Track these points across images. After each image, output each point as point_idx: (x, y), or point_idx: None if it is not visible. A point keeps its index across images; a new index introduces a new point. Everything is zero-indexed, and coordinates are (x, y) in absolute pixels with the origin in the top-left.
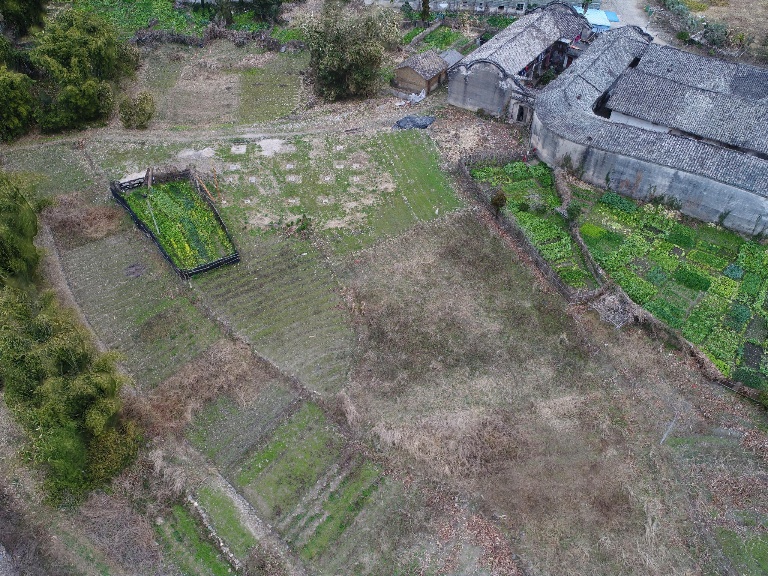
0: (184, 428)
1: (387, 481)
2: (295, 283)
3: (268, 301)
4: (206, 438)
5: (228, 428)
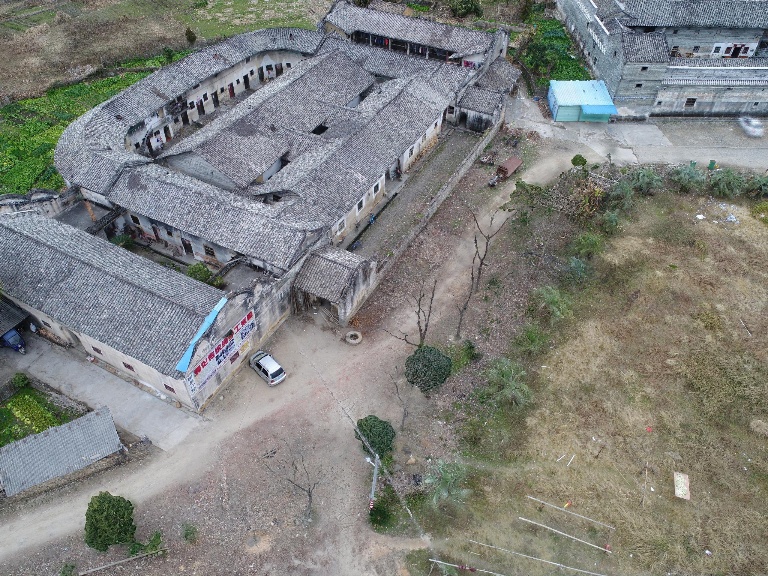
0: (77, 1)
1: None
2: (154, 8)
3: (143, 4)
4: (70, 5)
5: (73, 8)
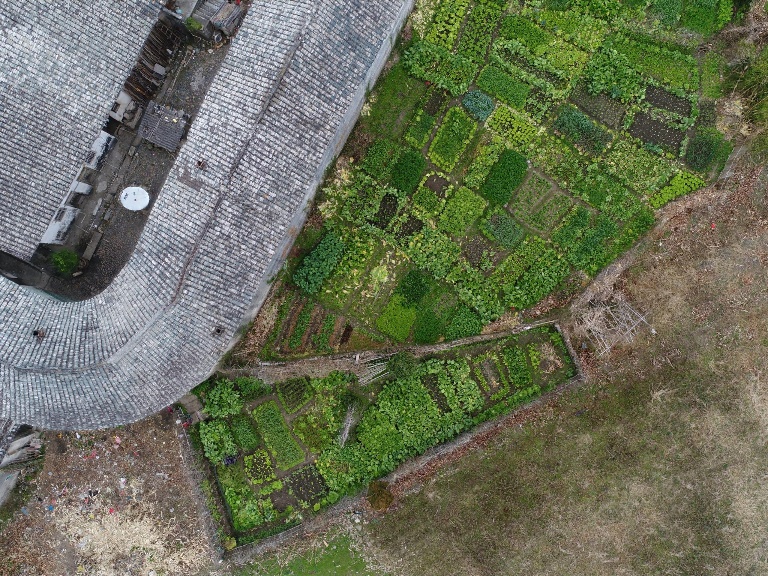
0: None
1: None
2: None
3: None
4: None
5: None
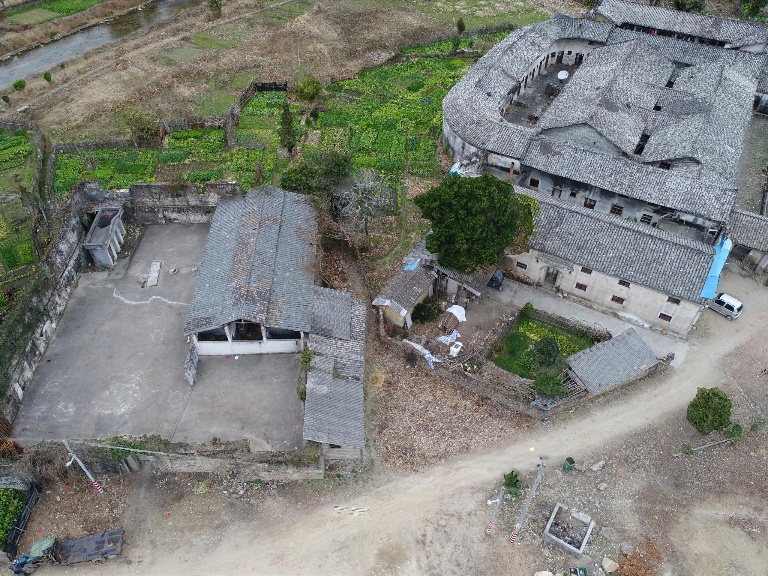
0: None
1: (289, 22)
2: None
3: None
4: None
5: None
